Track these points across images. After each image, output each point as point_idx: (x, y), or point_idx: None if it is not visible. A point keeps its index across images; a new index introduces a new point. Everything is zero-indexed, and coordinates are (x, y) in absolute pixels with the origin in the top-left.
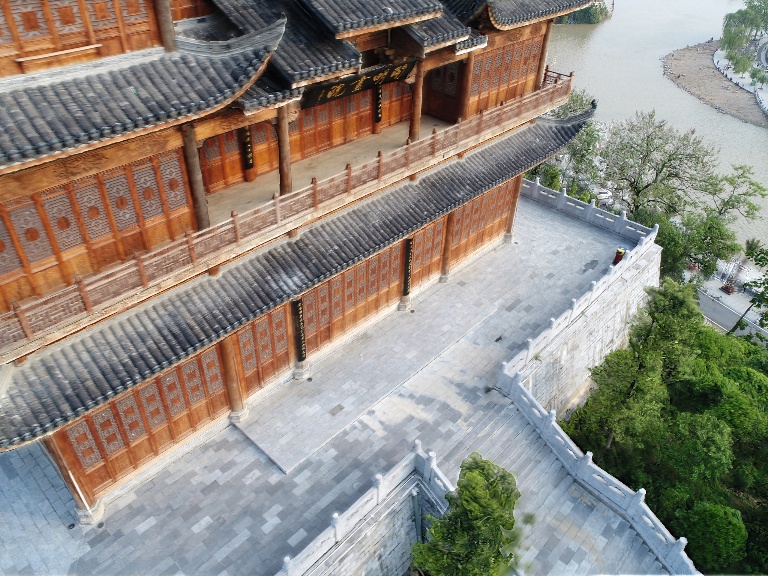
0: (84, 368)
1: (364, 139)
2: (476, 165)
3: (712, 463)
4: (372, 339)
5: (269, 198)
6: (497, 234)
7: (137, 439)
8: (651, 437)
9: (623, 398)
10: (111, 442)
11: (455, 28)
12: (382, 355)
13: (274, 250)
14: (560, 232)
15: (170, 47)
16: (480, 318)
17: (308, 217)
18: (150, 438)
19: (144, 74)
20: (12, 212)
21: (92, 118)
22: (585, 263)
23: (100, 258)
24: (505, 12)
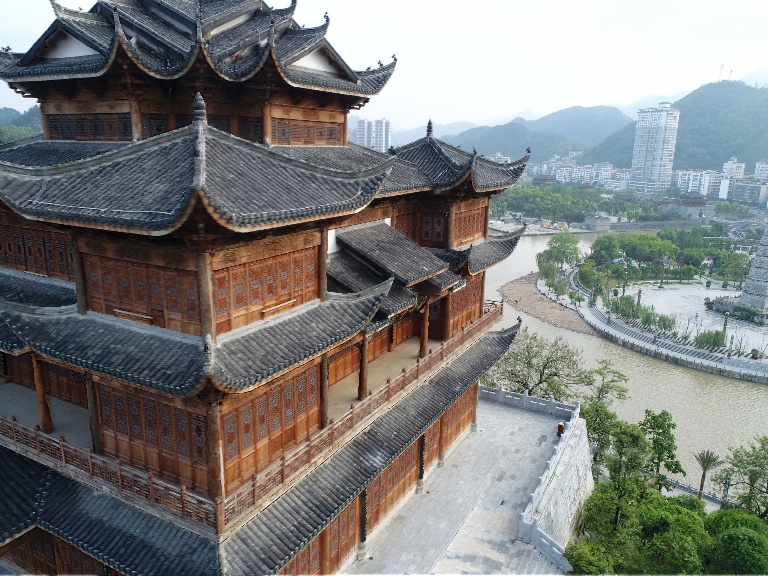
0: (266, 537)
1: (385, 355)
2: (458, 368)
3: (690, 567)
4: (406, 518)
5: (349, 400)
6: (467, 425)
7: None
8: (637, 563)
9: (614, 526)
10: None
11: (451, 276)
12: (420, 529)
13: (357, 439)
14: (509, 418)
15: (324, 299)
16: (482, 489)
17: (385, 408)
18: None
19: (314, 315)
20: (242, 412)
21: (304, 343)
22: (538, 438)
23: (273, 447)
24: None
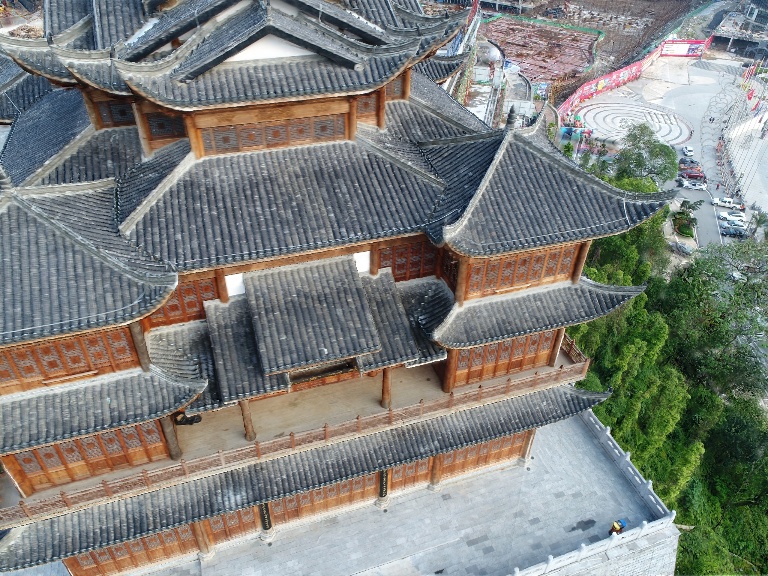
0: (71, 528)
1: (357, 380)
2: (458, 421)
3: None
4: (337, 526)
5: (241, 431)
6: (508, 457)
7: (121, 556)
8: None
9: None
10: (102, 555)
11: (405, 352)
12: (334, 546)
13: None
14: (582, 472)
15: (145, 370)
16: (436, 543)
17: (252, 462)
18: (132, 557)
19: (123, 387)
20: None
21: (73, 422)
22: (580, 520)
23: (95, 466)
24: (476, 331)
